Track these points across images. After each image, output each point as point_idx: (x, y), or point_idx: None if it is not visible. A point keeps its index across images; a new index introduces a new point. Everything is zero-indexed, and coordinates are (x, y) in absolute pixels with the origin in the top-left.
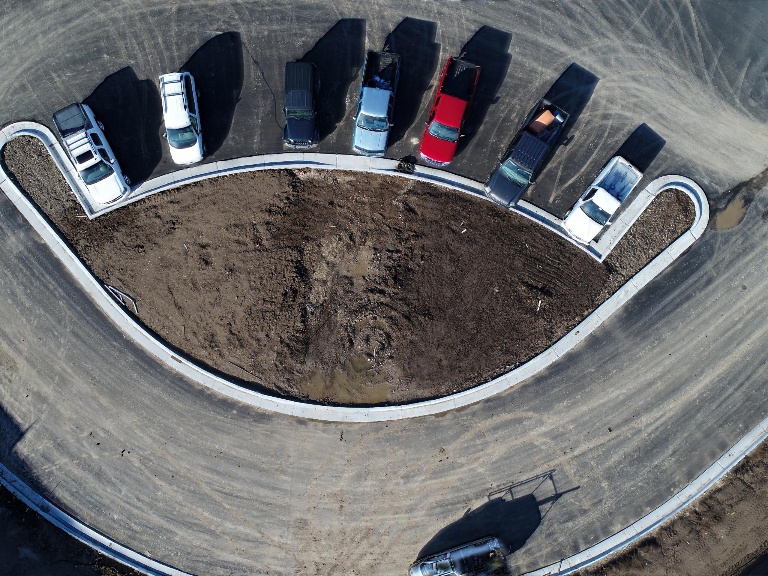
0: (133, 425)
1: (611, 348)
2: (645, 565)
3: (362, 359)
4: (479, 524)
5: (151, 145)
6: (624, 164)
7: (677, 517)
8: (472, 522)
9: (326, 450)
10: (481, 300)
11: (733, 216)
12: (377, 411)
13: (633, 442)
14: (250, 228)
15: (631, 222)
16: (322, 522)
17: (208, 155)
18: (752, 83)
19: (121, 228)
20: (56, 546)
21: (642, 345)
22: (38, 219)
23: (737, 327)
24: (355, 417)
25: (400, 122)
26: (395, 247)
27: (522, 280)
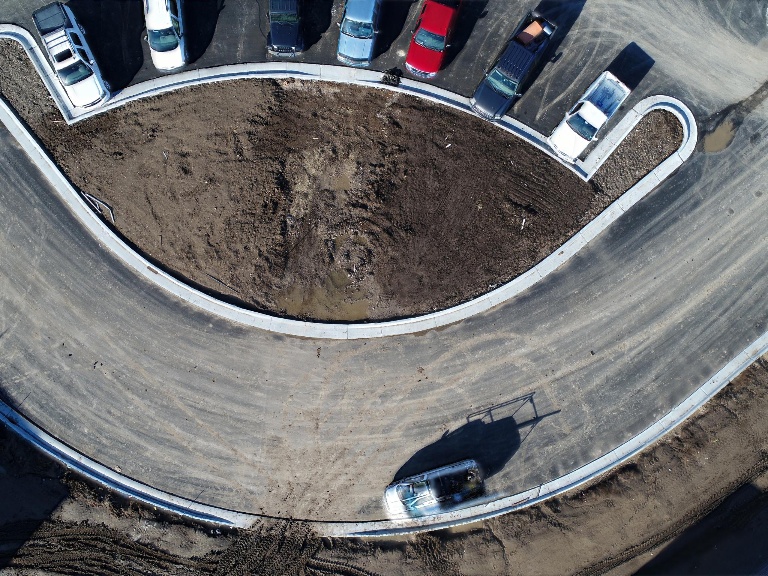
0: (106, 337)
1: (595, 270)
2: (625, 492)
3: (342, 275)
4: (457, 446)
5: (132, 51)
6: (612, 80)
7: (659, 444)
8: (450, 444)
9: (303, 367)
10: (464, 217)
11: (721, 139)
12: (356, 328)
13: (616, 366)
14: (231, 137)
15: (618, 141)
16: (297, 440)
17: (190, 62)
18: (743, 5)
19: (99, 134)
20: (24, 458)
21: (627, 268)
22: (15, 124)
23: (723, 252)
24: (333, 334)
25: (386, 34)
26: (378, 161)
27: (506, 197)
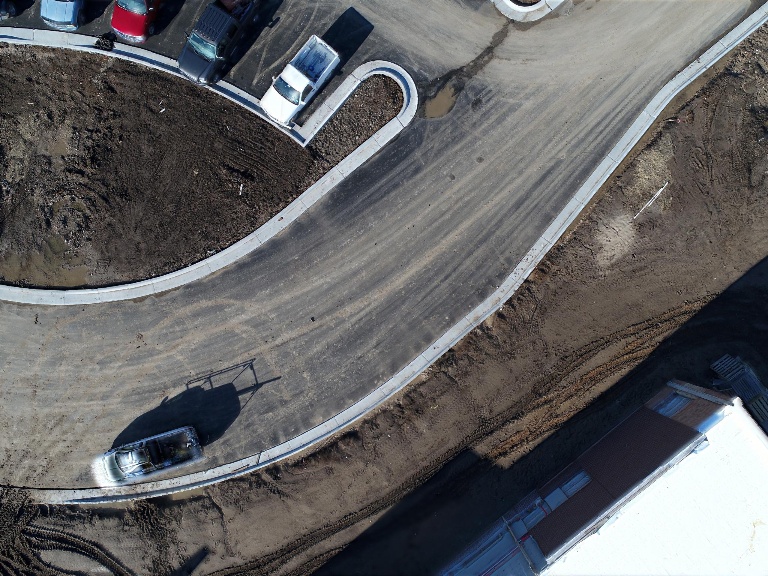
0: None
1: (316, 236)
2: (345, 458)
3: (60, 241)
4: (177, 413)
5: None
6: (322, 45)
7: (381, 411)
8: (169, 411)
9: (20, 333)
10: (180, 182)
11: (443, 105)
12: (73, 294)
13: (336, 332)
14: None
15: (335, 107)
16: (15, 407)
17: None
18: None
19: None
20: None
21: (347, 233)
22: None
23: (445, 217)
24: (50, 300)
25: None
26: (95, 127)
27: (223, 163)
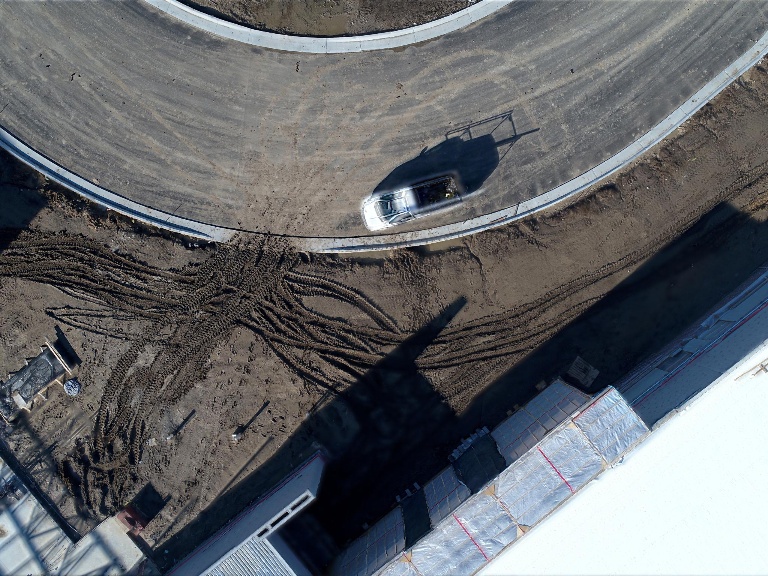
0: (84, 48)
1: None
2: (603, 209)
3: None
4: (436, 163)
5: None
6: None
7: (638, 164)
8: (429, 161)
9: (282, 81)
10: None
11: None
12: (335, 42)
13: (595, 85)
14: None
15: None
16: (275, 155)
17: None
18: None
19: None
20: (2, 168)
21: None
22: None
23: None
24: (312, 47)
25: None
26: None
27: None
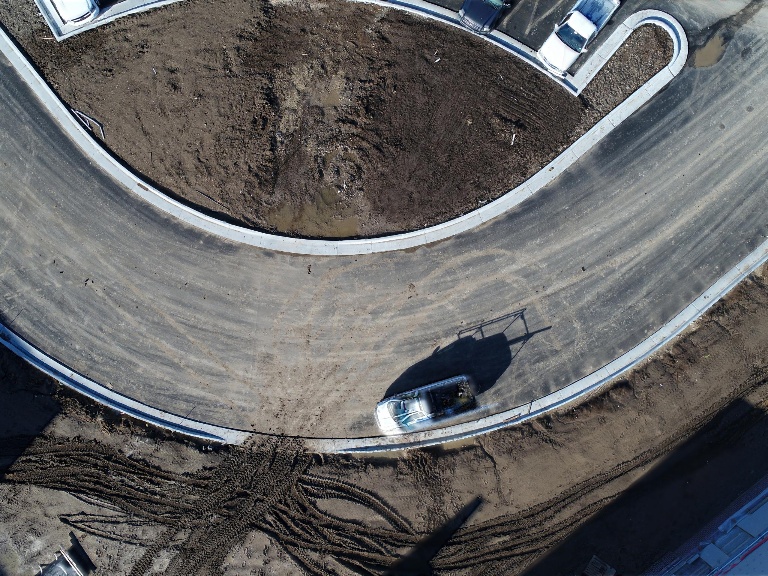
0: (97, 254)
1: (586, 186)
2: (617, 407)
3: (332, 192)
4: (448, 363)
5: None
6: None
7: (650, 360)
8: (441, 360)
9: (294, 283)
10: (454, 132)
11: (712, 54)
12: (346, 244)
13: (607, 282)
14: (220, 53)
15: (608, 56)
16: (288, 357)
17: None
18: None
19: (89, 51)
20: (16, 375)
21: (617, 183)
22: (5, 41)
23: (715, 167)
24: (324, 250)
25: None
26: (368, 77)
27: (496, 112)
